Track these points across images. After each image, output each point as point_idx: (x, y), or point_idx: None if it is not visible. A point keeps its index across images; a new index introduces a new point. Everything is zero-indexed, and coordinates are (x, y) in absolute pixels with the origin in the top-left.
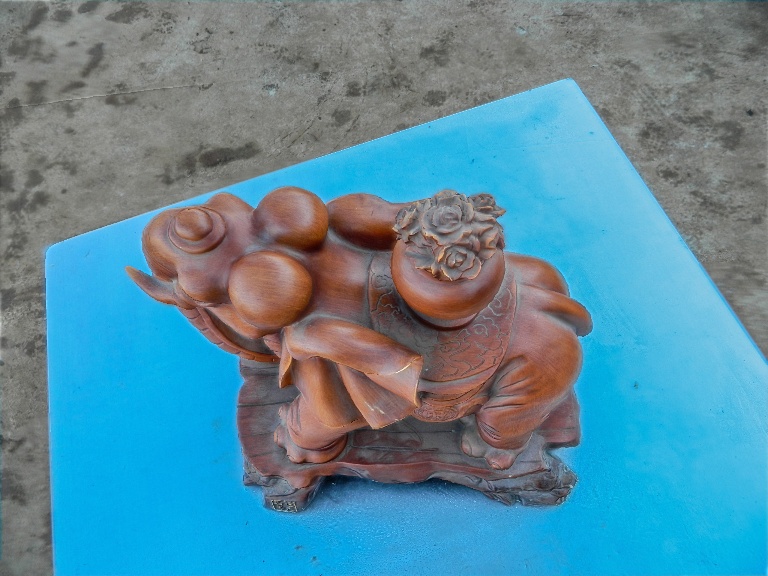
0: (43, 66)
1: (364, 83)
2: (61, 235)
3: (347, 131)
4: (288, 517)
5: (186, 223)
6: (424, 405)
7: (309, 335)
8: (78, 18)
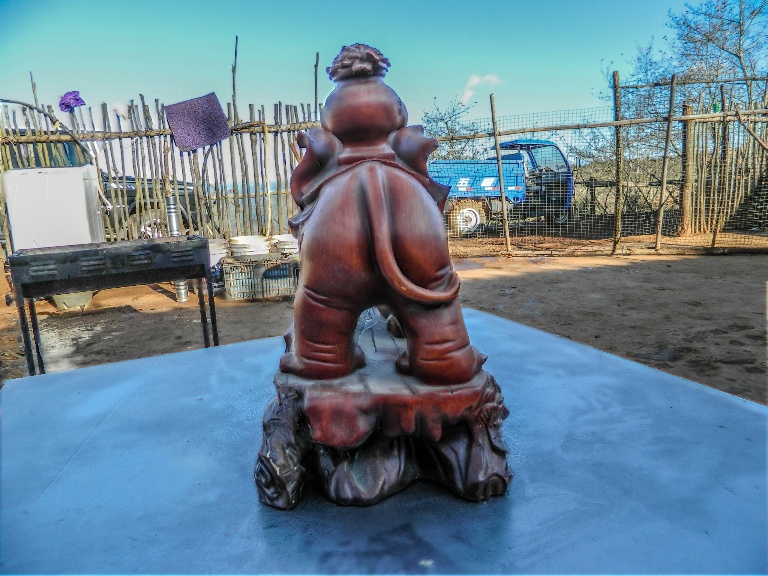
0: (693, 375)
1: None
2: None
3: None
4: None
5: None
6: None
7: None
8: (762, 376)
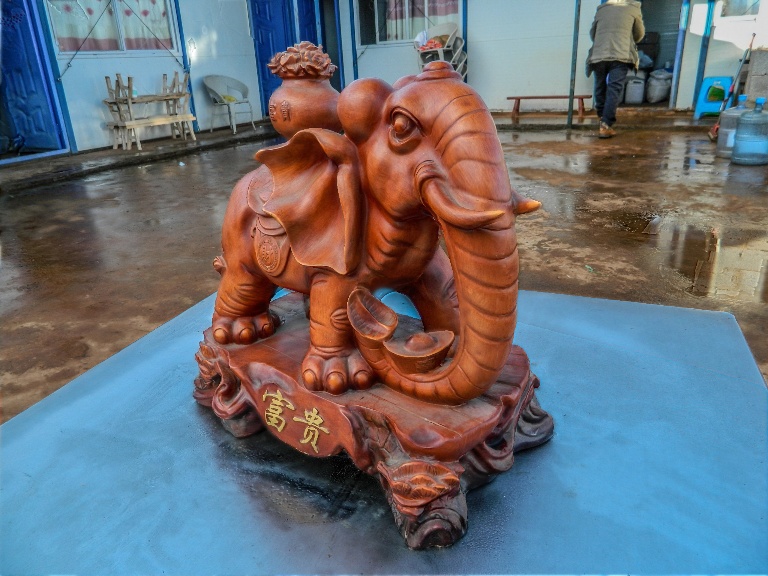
0: None
1: None
2: None
3: None
4: None
5: None
6: None
7: None
8: None
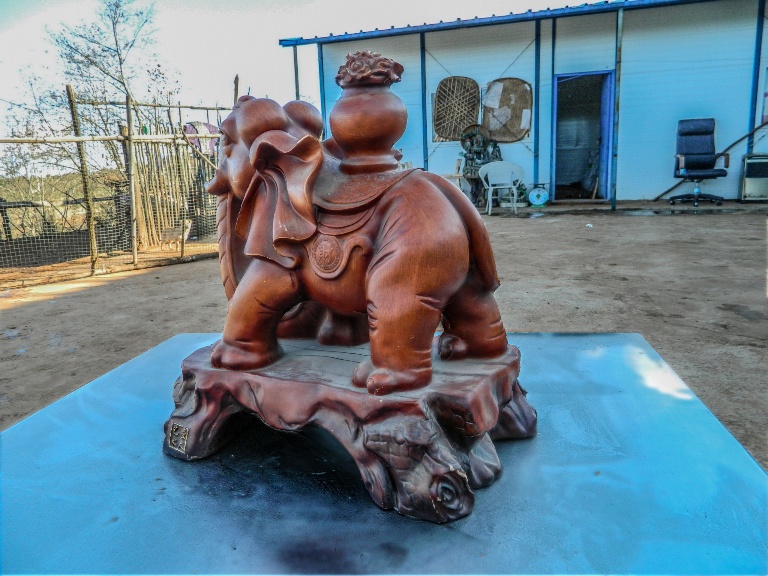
0: None
1: None
2: None
3: None
4: (174, 461)
5: None
6: (319, 237)
7: None
8: None
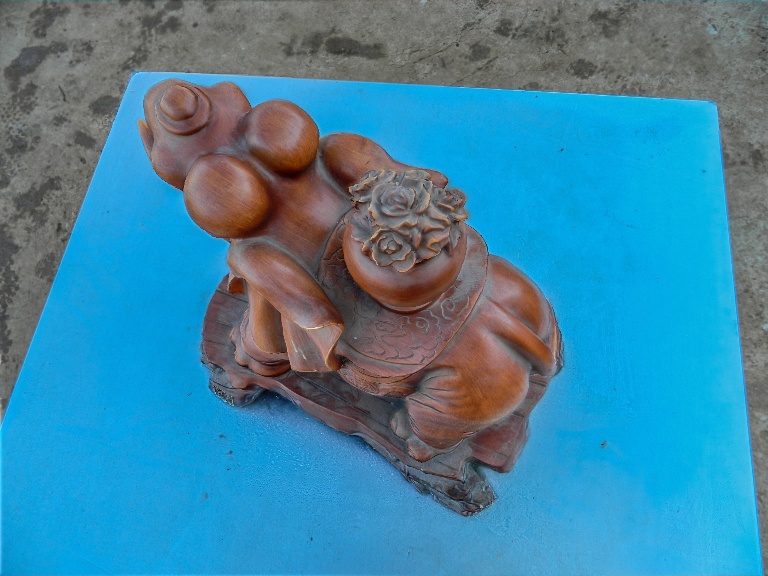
0: None
1: (518, 25)
2: (176, 66)
3: (478, 69)
4: (226, 406)
5: (170, 99)
6: (347, 369)
7: (244, 256)
8: None
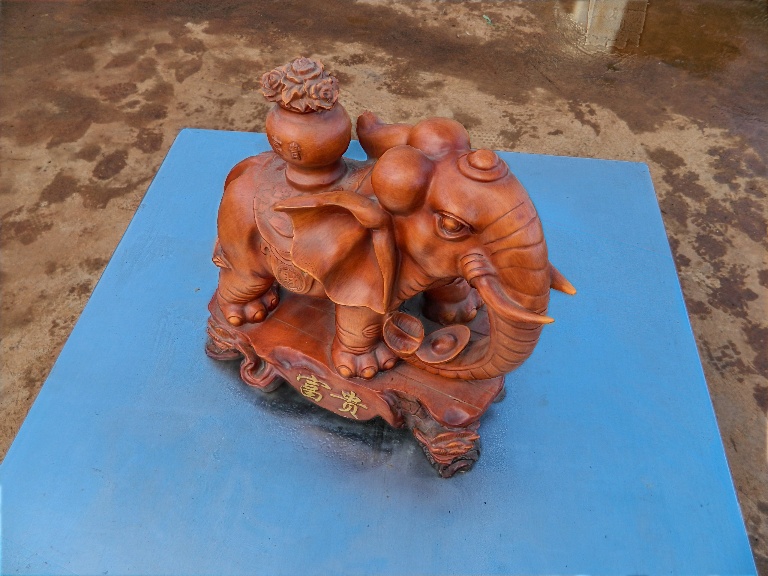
0: None
1: None
2: None
3: None
4: None
5: (488, 151)
6: None
7: None
8: None
